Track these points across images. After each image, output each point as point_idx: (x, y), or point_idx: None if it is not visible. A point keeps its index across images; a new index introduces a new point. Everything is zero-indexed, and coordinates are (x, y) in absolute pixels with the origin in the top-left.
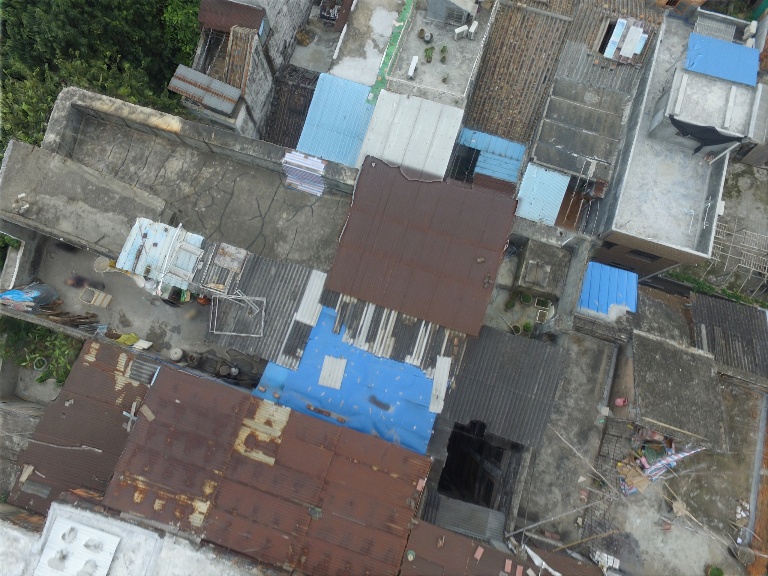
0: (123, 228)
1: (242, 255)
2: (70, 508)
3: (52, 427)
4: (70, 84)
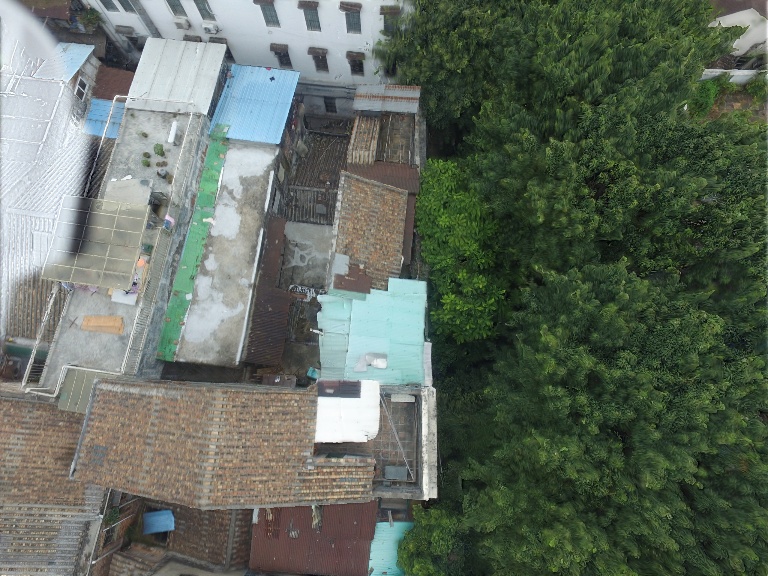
0: None
1: None
2: None
3: None
4: None
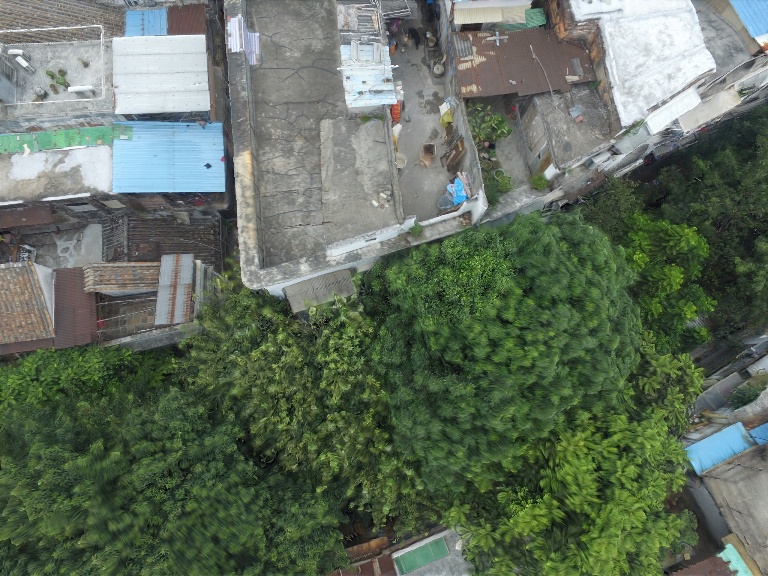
0: (361, 135)
1: (342, 8)
2: (573, 8)
3: (535, 84)
4: (229, 374)
